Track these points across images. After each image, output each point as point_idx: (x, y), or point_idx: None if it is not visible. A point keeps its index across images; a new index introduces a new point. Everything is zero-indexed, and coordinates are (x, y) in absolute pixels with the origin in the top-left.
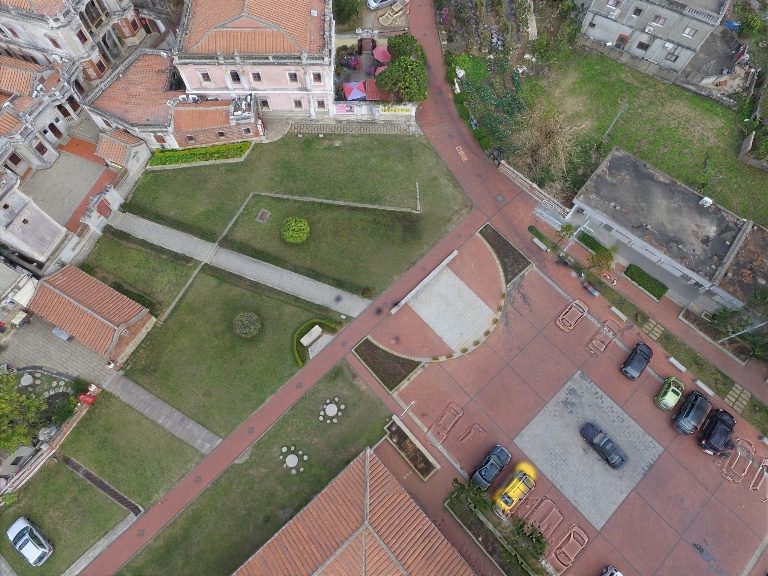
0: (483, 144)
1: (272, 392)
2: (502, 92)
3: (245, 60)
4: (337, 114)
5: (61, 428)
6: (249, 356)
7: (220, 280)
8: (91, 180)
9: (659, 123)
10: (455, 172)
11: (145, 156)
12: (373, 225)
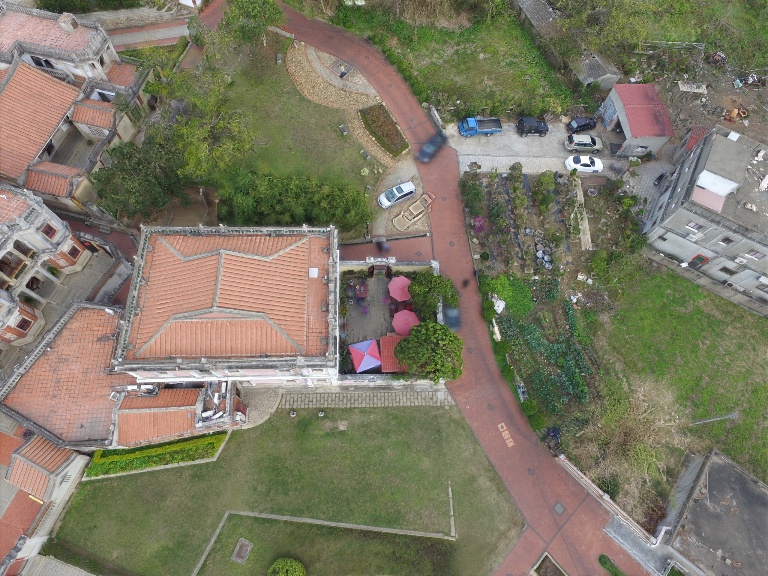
0: (535, 427)
1: None
2: (553, 333)
3: (217, 363)
4: (342, 383)
5: None
6: None
7: None
8: (4, 501)
9: (753, 379)
10: (499, 466)
11: (80, 465)
12: (392, 562)
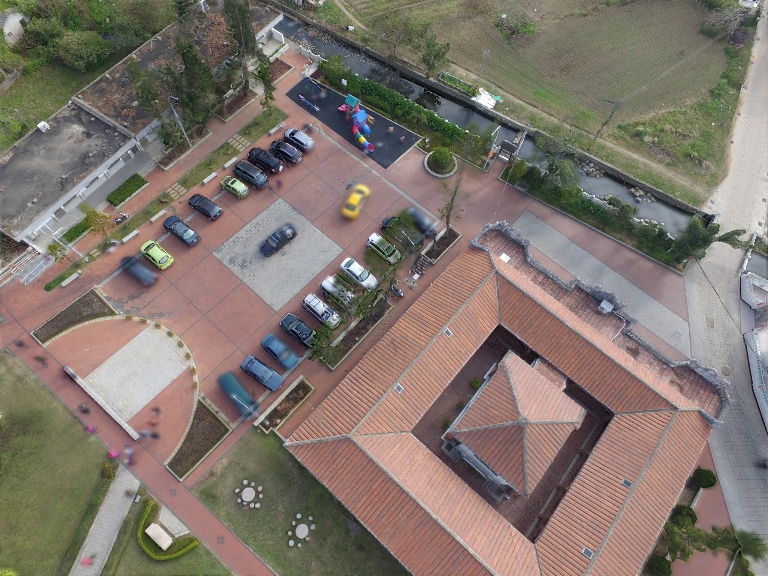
0: None
1: (228, 575)
2: None
3: None
4: None
5: None
6: None
7: None
8: None
9: None
10: None
11: None
12: (8, 477)
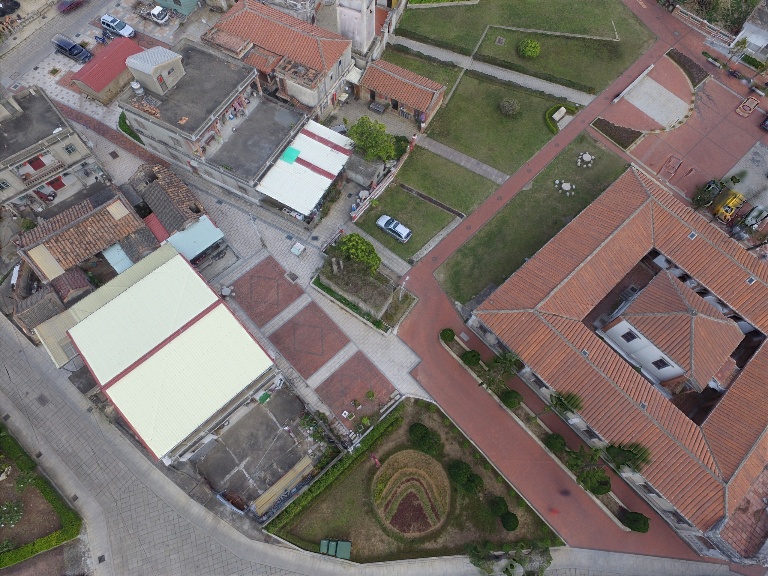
0: None
1: (538, 149)
2: None
3: None
4: None
5: (400, 160)
6: (515, 127)
7: (480, 80)
8: None
9: None
10: (639, 15)
11: None
12: (585, 48)
